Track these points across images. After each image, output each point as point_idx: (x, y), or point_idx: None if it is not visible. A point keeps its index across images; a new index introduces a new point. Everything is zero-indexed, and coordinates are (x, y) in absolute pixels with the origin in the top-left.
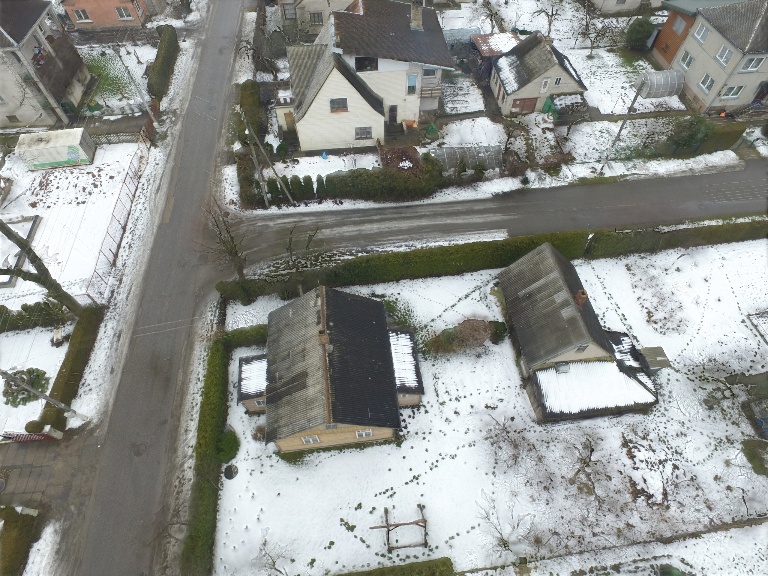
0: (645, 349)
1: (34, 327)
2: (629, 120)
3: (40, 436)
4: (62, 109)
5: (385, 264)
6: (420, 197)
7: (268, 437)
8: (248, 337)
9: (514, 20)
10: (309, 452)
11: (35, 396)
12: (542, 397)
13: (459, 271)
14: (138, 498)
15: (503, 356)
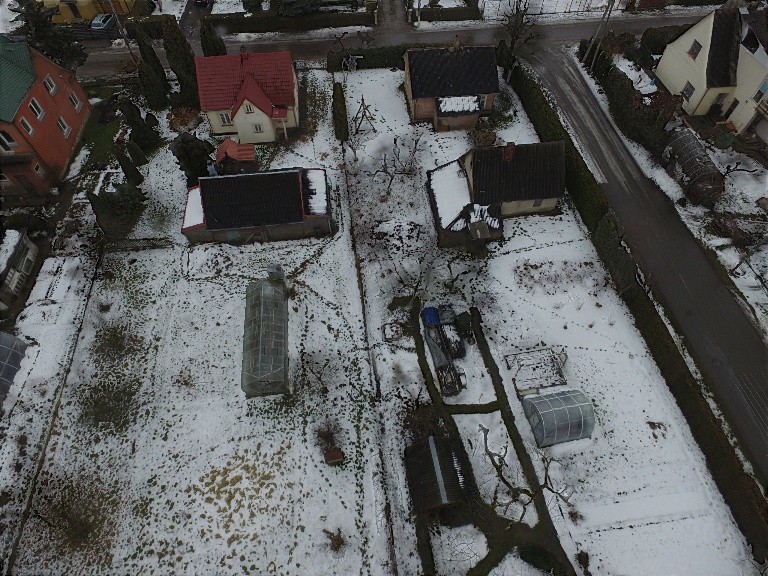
0: (486, 224)
1: (466, 3)
2: None
3: None
4: None
5: (535, 97)
6: (626, 133)
7: None
8: None
9: None
10: None
11: None
12: (440, 168)
13: None
14: None
15: None
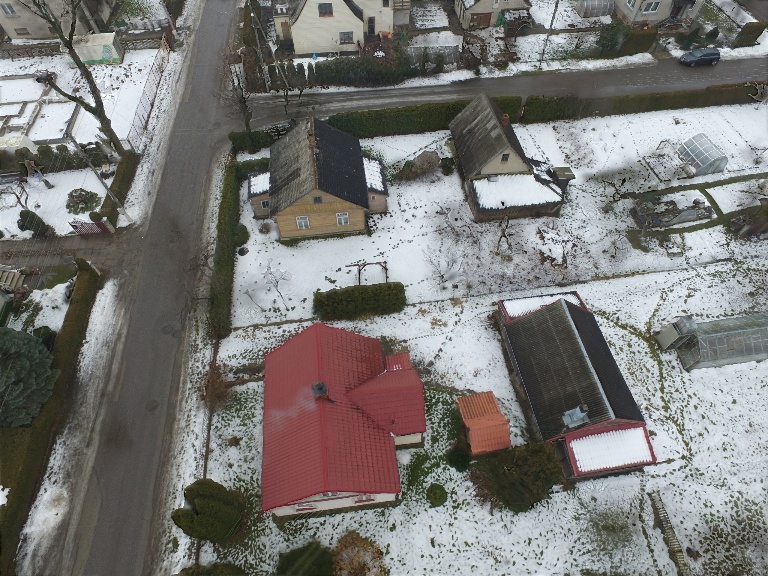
0: (556, 167)
1: (85, 168)
2: (568, 33)
3: (98, 227)
4: (95, 22)
5: (361, 119)
6: (392, 84)
7: (271, 213)
8: (255, 167)
9: None
10: (302, 240)
11: (91, 207)
12: (477, 198)
13: (421, 130)
14: (174, 266)
15: (452, 182)
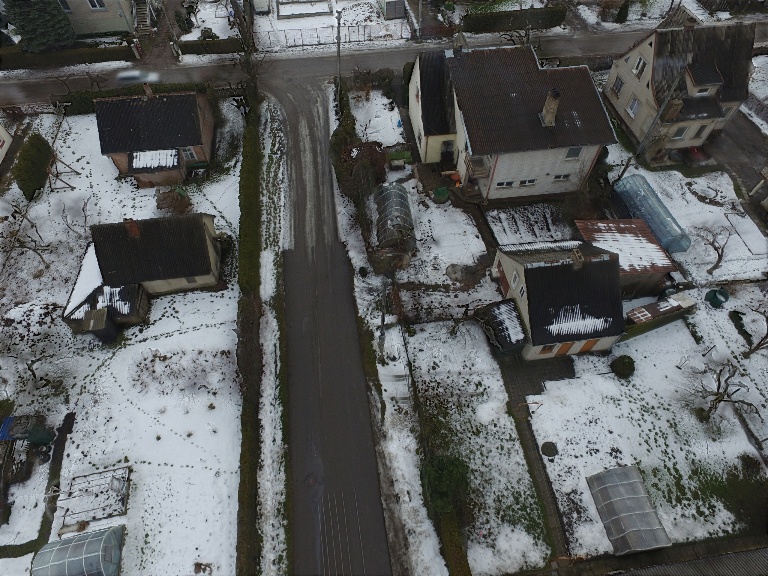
0: (104, 312)
1: None
2: (517, 435)
3: None
4: None
5: None
6: None
7: None
8: None
9: None
10: None
11: None
12: None
13: None
14: None
15: None
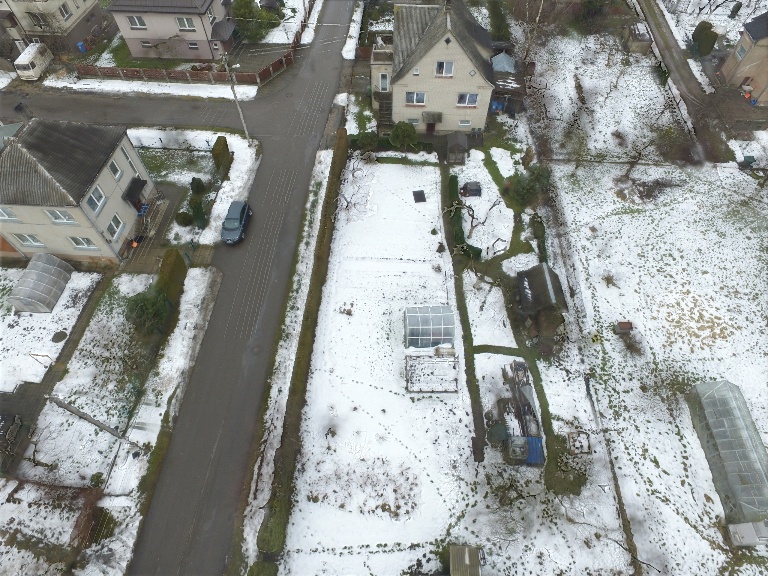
0: (453, 575)
1: None
2: (75, 352)
3: None
4: None
5: None
6: None
7: None
8: None
9: None
10: None
11: None
12: None
13: None
14: None
15: None
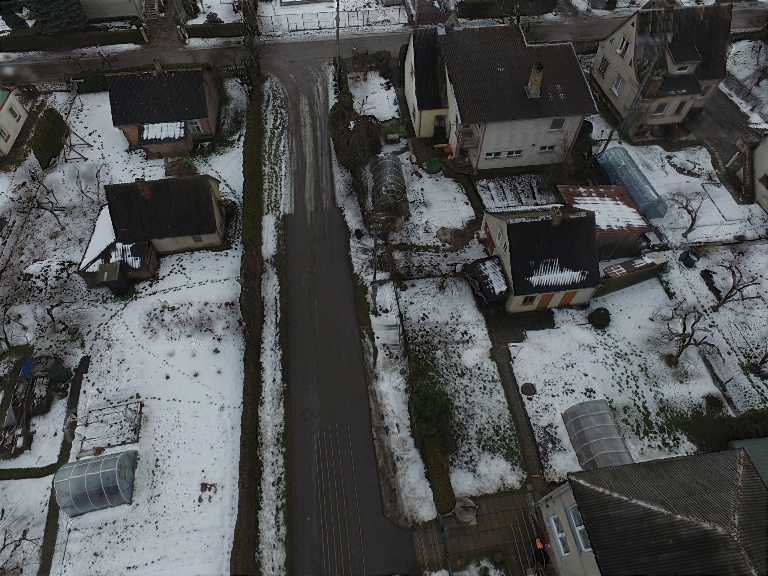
0: (117, 265)
1: None
2: (499, 377)
3: None
4: None
5: None
6: None
7: None
8: None
9: (748, 269)
10: None
11: None
12: None
13: None
14: None
15: None
